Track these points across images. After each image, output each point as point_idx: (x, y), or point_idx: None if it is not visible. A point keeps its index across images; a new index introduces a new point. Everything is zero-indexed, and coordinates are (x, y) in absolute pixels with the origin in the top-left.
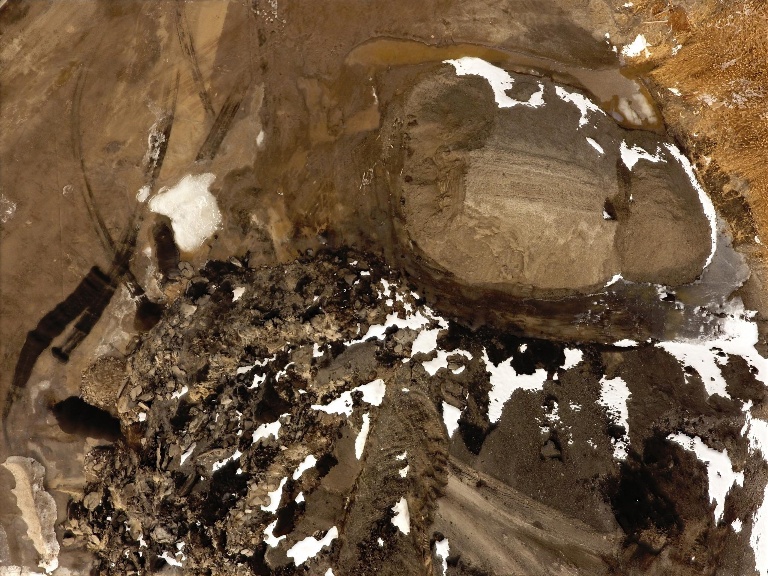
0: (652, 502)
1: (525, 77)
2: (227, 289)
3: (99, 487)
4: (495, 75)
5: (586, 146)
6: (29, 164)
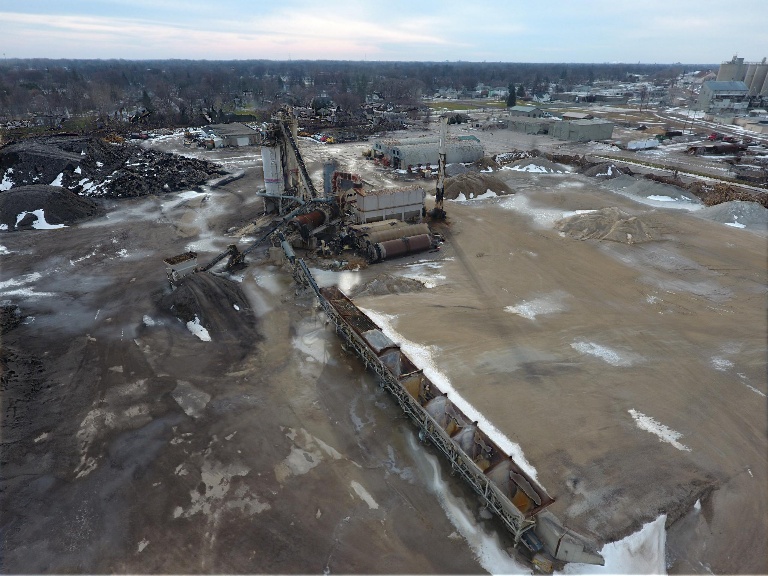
0: (3, 158)
1: (25, 228)
2: (171, 186)
3: (210, 168)
4: (42, 225)
5: (0, 202)
6: (255, 191)
